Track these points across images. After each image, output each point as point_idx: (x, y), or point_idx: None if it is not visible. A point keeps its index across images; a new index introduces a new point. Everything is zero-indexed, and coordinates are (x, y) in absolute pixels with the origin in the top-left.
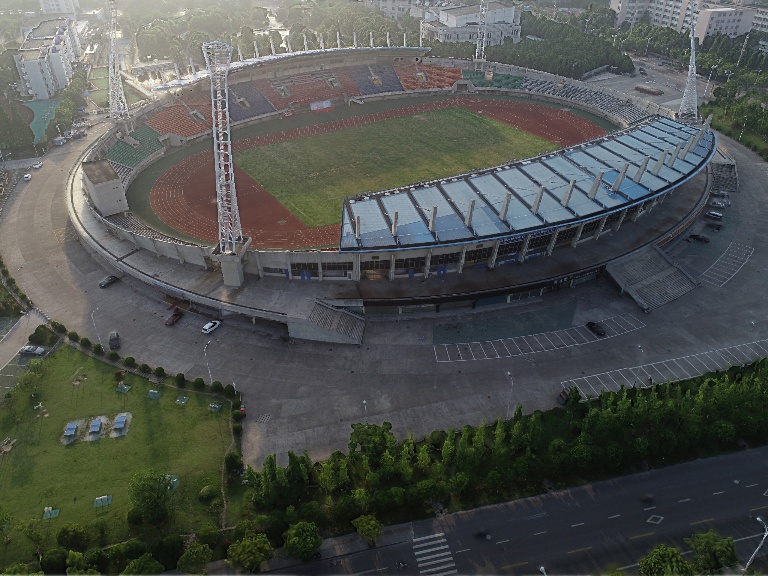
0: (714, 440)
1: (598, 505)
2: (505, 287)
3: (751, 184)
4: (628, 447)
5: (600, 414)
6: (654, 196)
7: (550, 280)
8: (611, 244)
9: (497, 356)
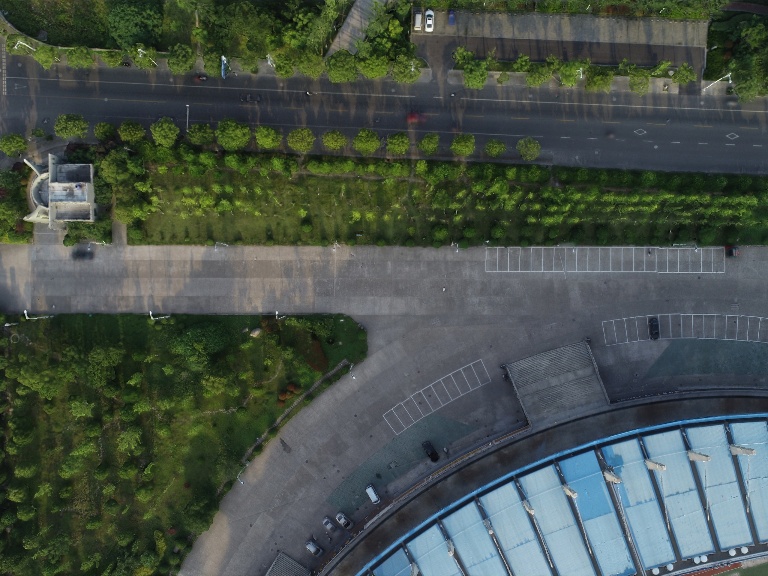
0: (659, 174)
1: (763, 157)
2: (741, 391)
3: (242, 569)
4: (734, 181)
5: (757, 202)
6: (560, 454)
7: (686, 393)
8: (574, 445)
9: (762, 320)
